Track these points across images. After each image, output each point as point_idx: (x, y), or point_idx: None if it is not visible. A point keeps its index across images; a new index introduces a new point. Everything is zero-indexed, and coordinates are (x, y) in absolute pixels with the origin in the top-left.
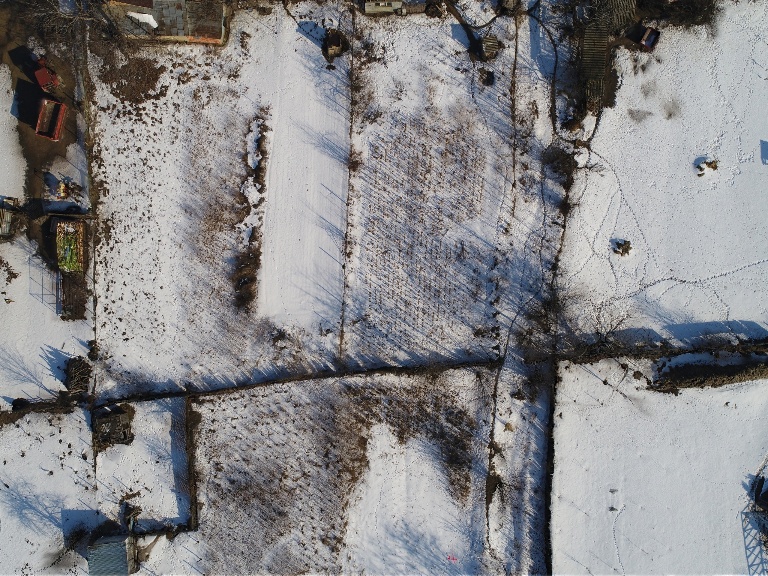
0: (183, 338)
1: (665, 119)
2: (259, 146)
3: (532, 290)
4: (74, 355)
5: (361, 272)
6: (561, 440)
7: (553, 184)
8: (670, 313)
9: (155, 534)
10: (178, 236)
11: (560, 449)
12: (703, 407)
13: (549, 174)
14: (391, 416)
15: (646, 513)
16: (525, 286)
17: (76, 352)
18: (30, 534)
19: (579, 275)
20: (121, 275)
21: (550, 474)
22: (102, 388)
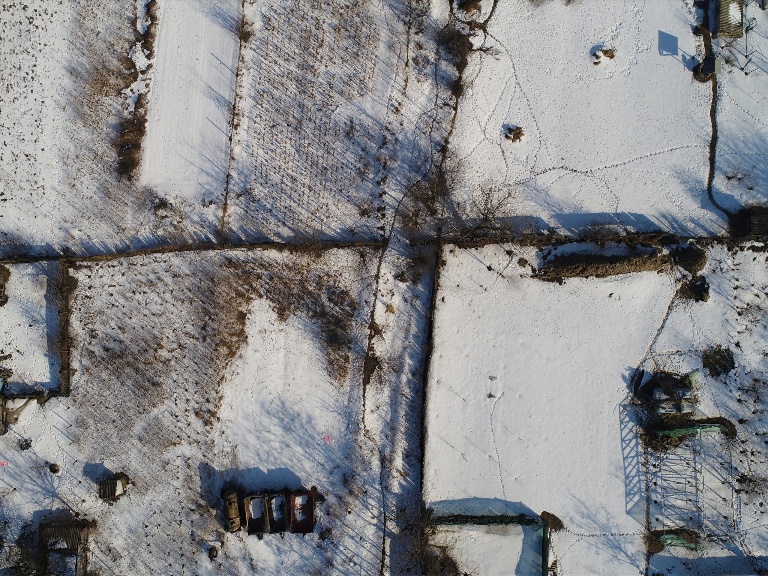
0: (63, 202)
1: (564, 5)
2: (148, 10)
3: (420, 171)
4: None
5: (248, 145)
6: (442, 324)
7: (447, 65)
8: (559, 202)
9: (24, 396)
10: (62, 98)
11: (441, 333)
12: (587, 297)
13: (443, 55)
14: (272, 292)
15: (524, 401)
16: (413, 167)
17: None
18: None
19: (469, 159)
20: (2, 134)
21: (428, 356)
22: None
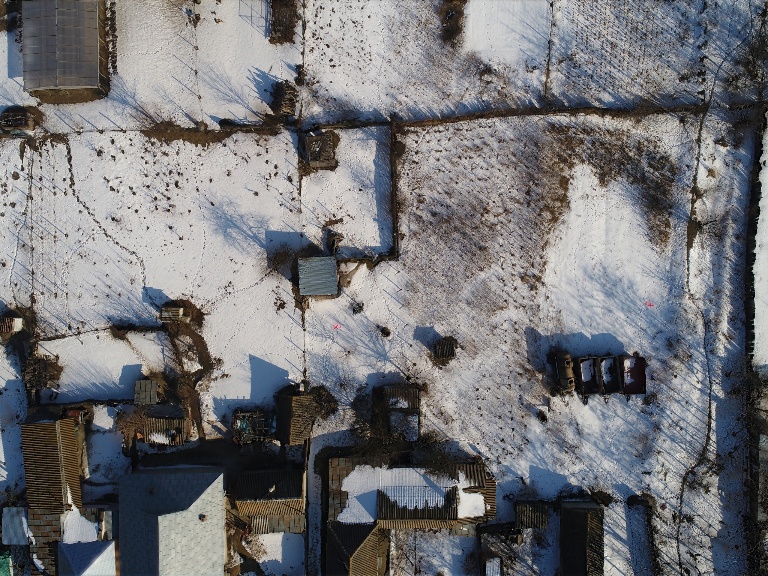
0: (389, 69)
1: None
2: None
3: (740, 36)
4: (281, 79)
5: (568, 11)
6: (764, 188)
7: None
8: None
9: (359, 258)
10: None
11: (763, 197)
12: None
13: None
14: (594, 157)
15: None
16: (733, 32)
17: (283, 76)
18: (234, 253)
19: None
20: (330, 1)
21: (754, 218)
22: (308, 112)
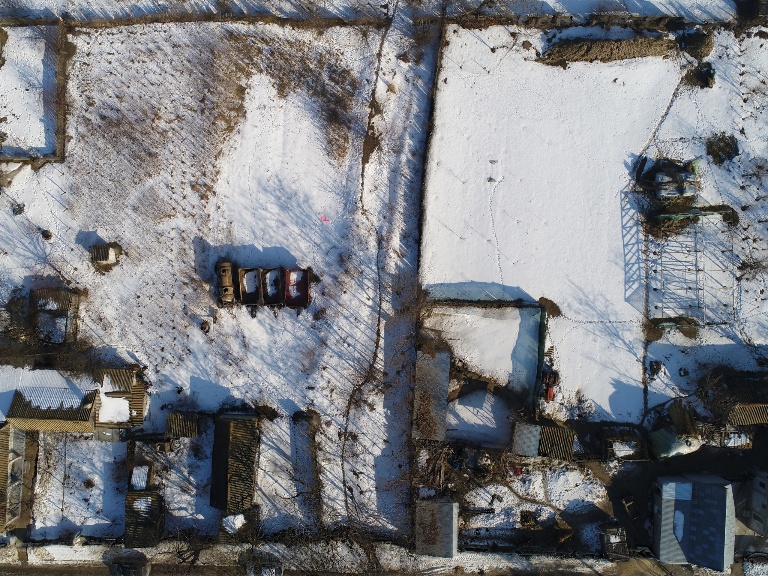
0: None
1: None
2: None
3: None
4: None
5: None
6: (444, 105)
7: None
8: None
9: None
10: None
11: (442, 114)
12: (591, 83)
13: None
14: (272, 67)
15: (524, 186)
16: None
17: None
18: None
19: None
20: None
21: (429, 135)
22: None
